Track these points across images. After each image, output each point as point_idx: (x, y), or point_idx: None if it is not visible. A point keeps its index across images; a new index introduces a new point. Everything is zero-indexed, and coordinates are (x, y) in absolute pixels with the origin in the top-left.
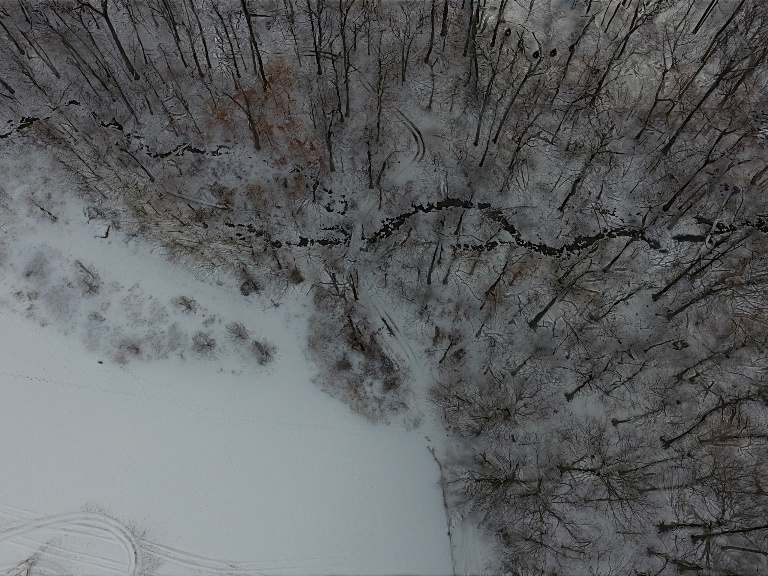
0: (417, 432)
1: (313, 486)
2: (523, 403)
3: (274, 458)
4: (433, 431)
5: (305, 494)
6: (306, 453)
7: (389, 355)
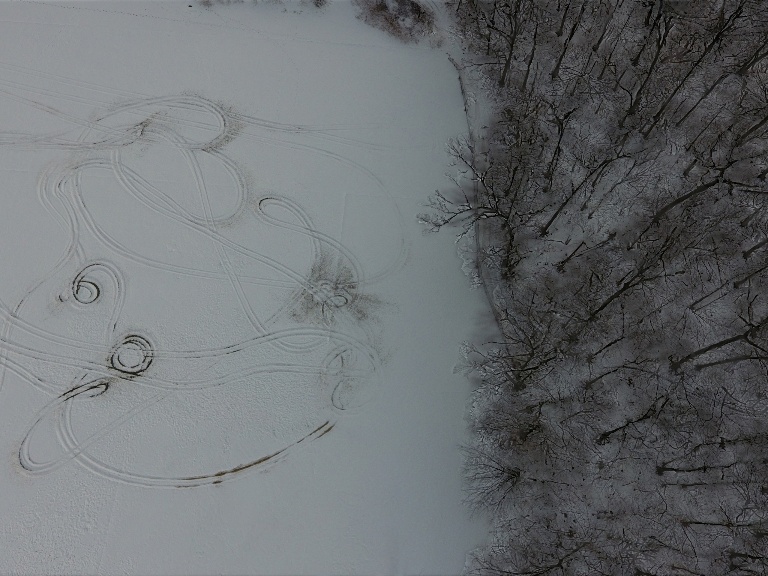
0: (440, 50)
1: (360, 81)
2: (523, 37)
3: (329, 64)
4: (452, 50)
5: (354, 86)
6: (354, 61)
7: (417, 3)
